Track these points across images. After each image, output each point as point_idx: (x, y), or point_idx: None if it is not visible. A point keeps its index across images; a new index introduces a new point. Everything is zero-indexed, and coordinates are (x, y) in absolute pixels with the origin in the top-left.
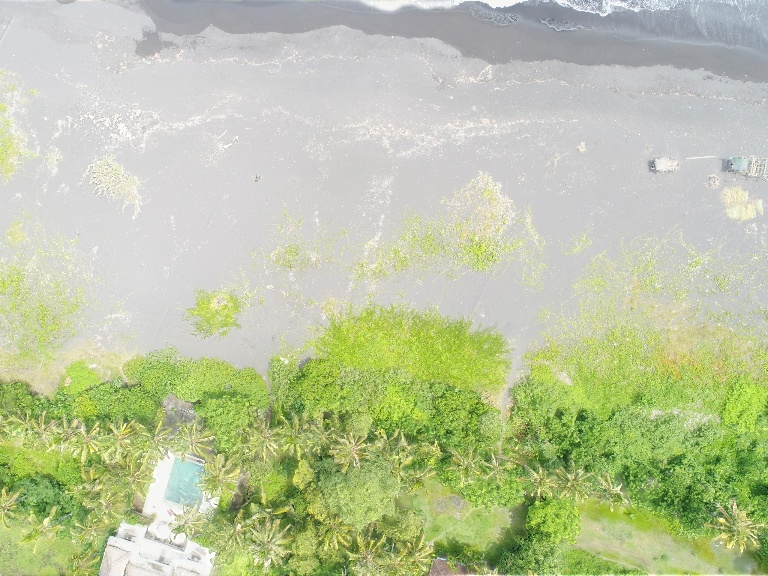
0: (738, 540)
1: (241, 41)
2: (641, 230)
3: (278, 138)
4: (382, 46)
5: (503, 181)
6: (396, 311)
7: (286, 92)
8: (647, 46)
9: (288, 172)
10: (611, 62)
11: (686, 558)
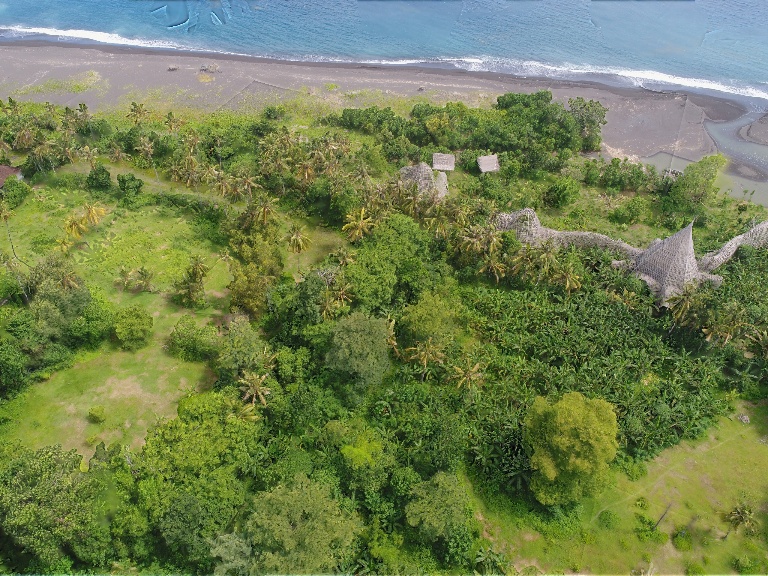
0: (166, 161)
1: (7, 47)
2: (158, 84)
3: (3, 62)
4: (69, 49)
5: (100, 72)
6: (25, 103)
7: (16, 54)
8: (184, 54)
9: (0, 69)
10: (166, 55)
11: (139, 176)
